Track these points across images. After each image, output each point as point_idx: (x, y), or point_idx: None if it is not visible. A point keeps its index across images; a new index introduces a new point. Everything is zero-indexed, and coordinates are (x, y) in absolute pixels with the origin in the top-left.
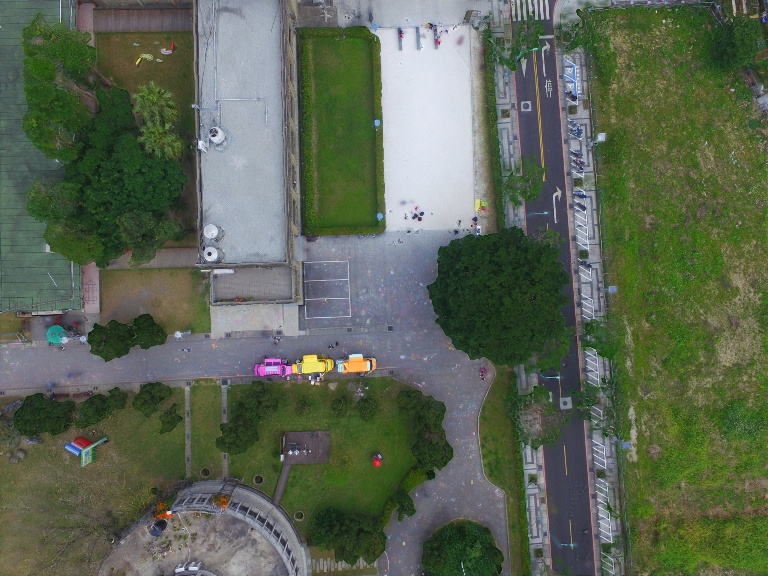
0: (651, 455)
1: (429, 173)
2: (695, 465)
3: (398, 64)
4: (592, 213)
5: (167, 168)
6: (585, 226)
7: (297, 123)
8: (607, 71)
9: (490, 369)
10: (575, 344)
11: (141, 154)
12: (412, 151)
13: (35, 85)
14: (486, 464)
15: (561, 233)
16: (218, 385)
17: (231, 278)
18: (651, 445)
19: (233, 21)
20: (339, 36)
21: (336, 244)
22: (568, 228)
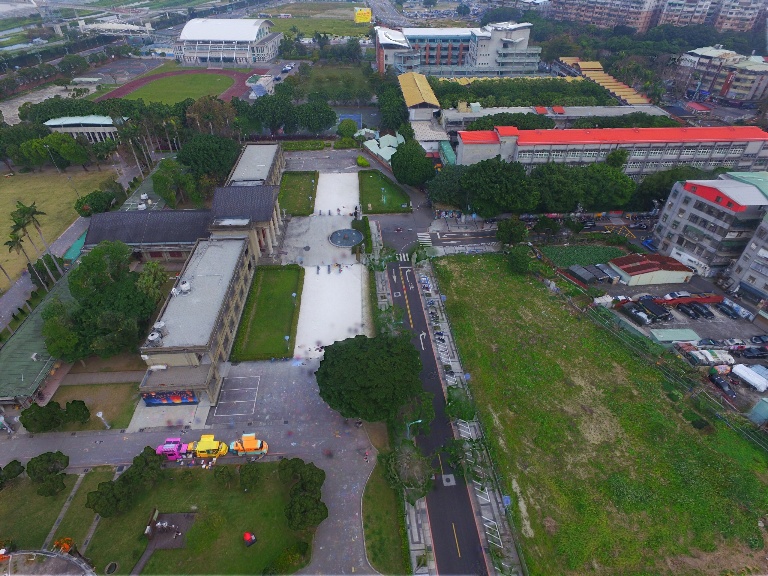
0: (547, 529)
1: (330, 327)
2: (598, 537)
3: (315, 280)
4: (450, 344)
5: (146, 299)
6: (446, 351)
7: (243, 305)
8: (446, 277)
9: (374, 453)
10: (450, 429)
11: (133, 289)
12: (319, 317)
13: (89, 256)
14: (369, 546)
15: (428, 356)
16: (113, 471)
17: (162, 374)
18: (544, 518)
19: (216, 249)
20: (281, 270)
21: (253, 366)
22: (433, 353)
